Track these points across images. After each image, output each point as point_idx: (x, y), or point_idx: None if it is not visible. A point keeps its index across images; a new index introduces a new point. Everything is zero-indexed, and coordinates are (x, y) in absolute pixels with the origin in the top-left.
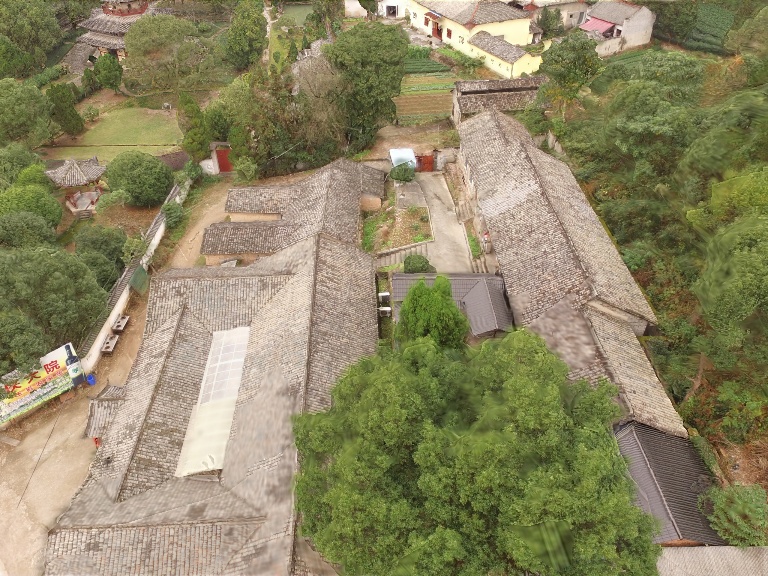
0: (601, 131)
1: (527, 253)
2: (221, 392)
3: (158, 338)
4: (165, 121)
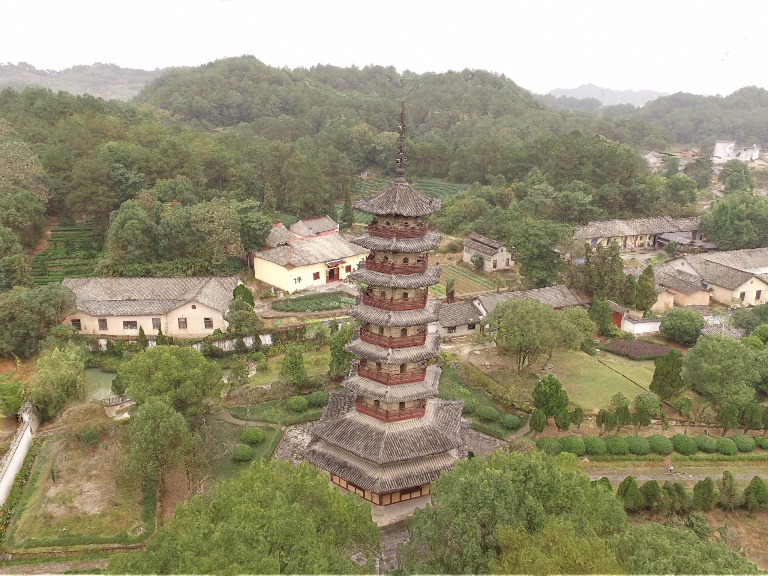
0: (572, 212)
1: (654, 226)
2: (762, 270)
3: (767, 279)
4: (571, 376)
